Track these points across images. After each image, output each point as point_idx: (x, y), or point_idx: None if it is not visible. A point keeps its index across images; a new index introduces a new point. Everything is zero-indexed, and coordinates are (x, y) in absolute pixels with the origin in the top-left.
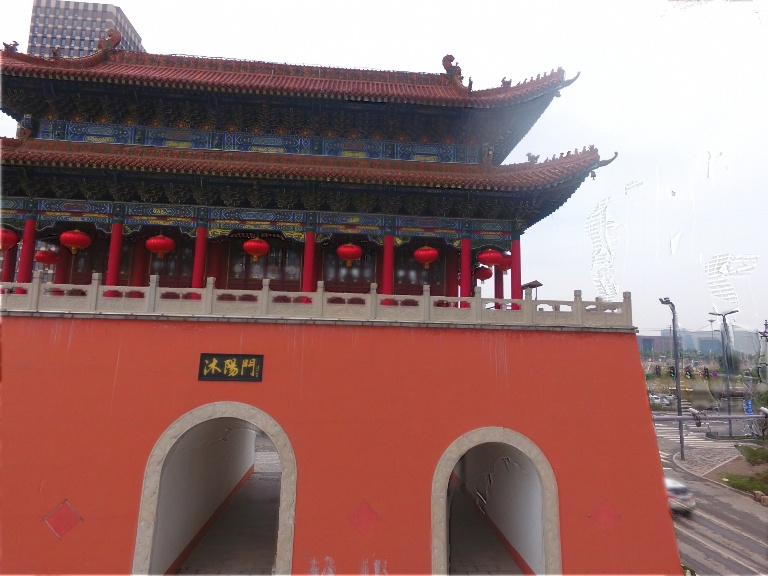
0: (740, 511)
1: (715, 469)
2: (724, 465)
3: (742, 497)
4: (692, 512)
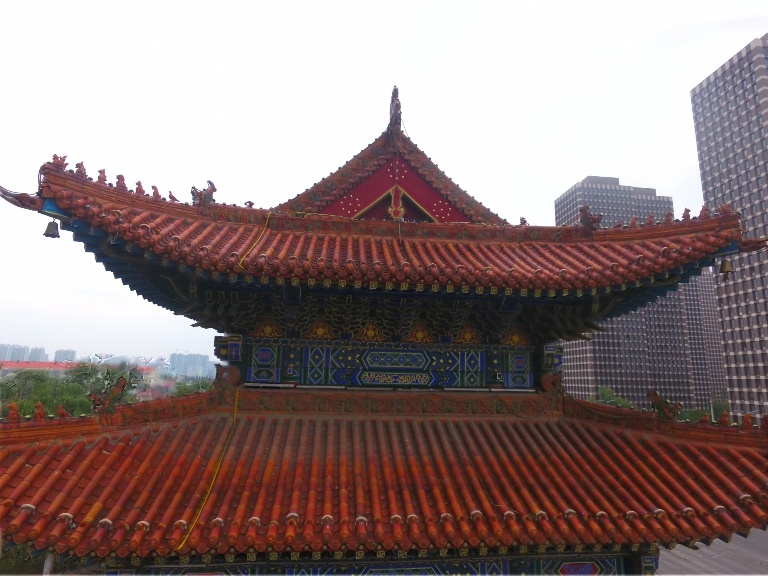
0: None
1: None
2: None
3: None
4: None
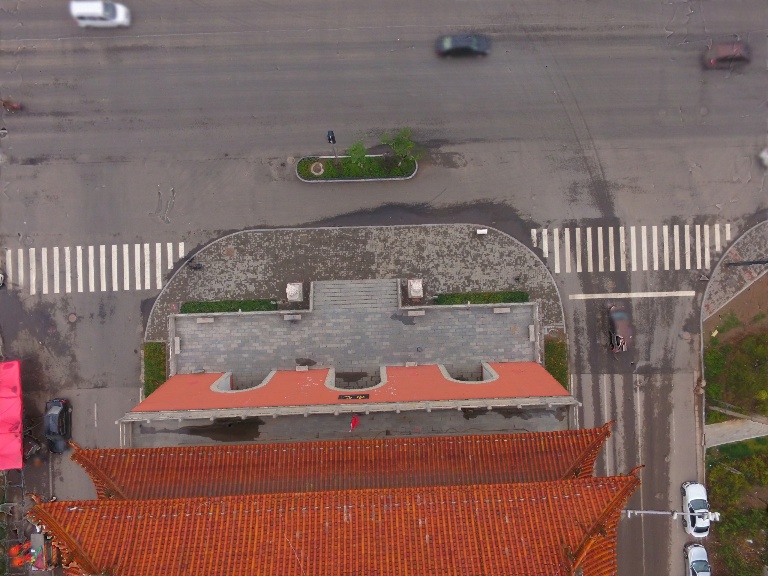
0: (668, 402)
1: (731, 301)
2: (751, 287)
3: (694, 373)
4: (634, 404)
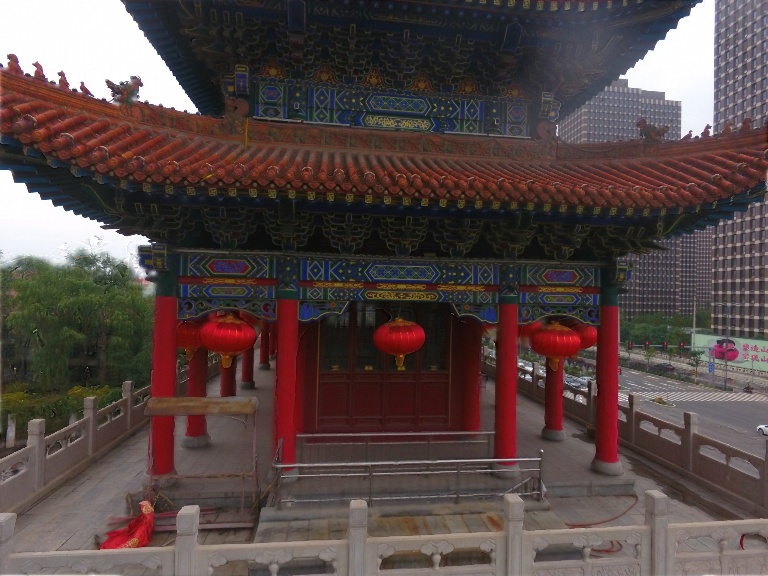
0: None
1: None
2: None
3: None
4: None
